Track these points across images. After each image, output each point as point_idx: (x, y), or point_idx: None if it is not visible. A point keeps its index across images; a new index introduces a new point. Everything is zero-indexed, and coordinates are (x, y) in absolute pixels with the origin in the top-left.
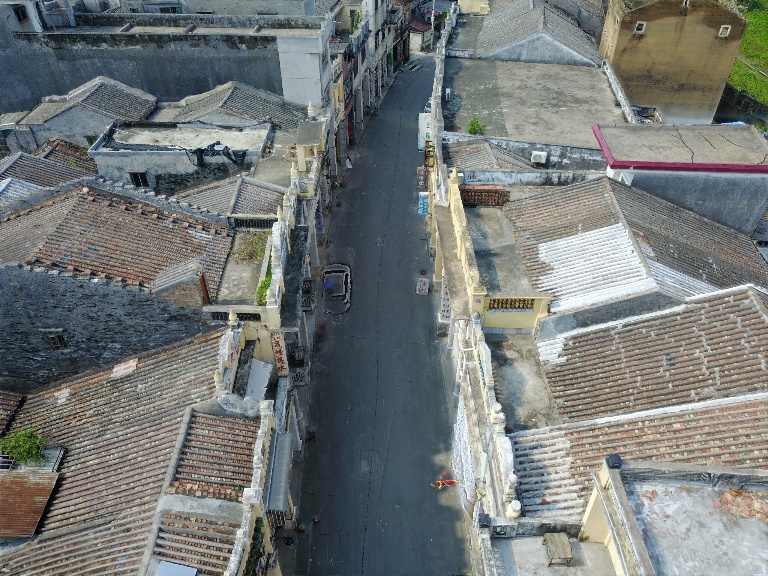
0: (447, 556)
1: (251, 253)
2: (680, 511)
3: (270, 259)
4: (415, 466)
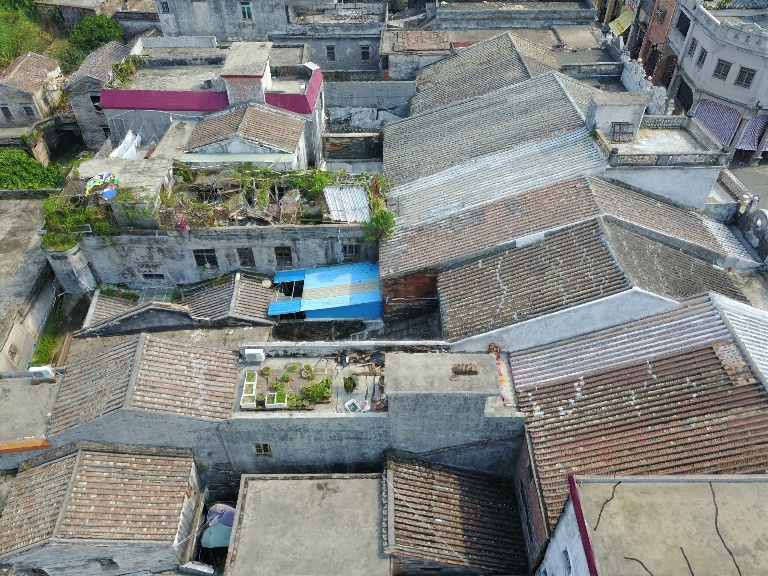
0: None
1: None
2: (682, 156)
3: None
4: None
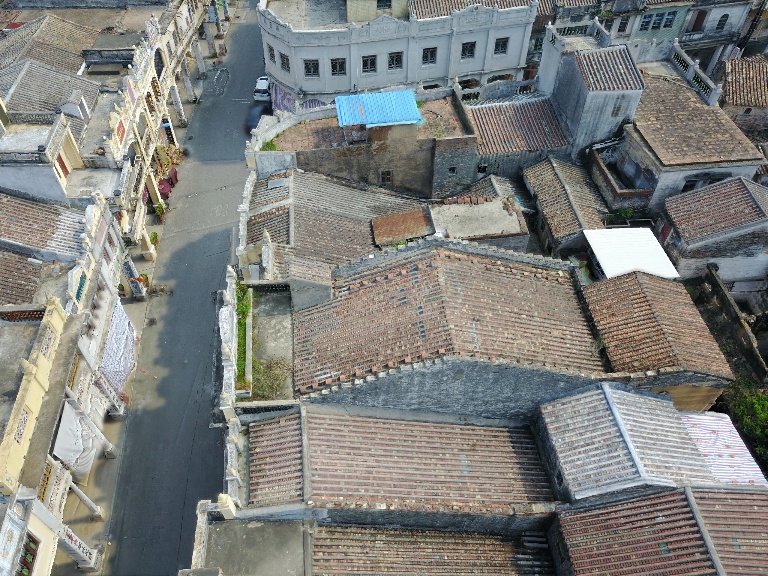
0: (157, 334)
1: (269, 368)
2: None
3: (245, 349)
4: (167, 392)
